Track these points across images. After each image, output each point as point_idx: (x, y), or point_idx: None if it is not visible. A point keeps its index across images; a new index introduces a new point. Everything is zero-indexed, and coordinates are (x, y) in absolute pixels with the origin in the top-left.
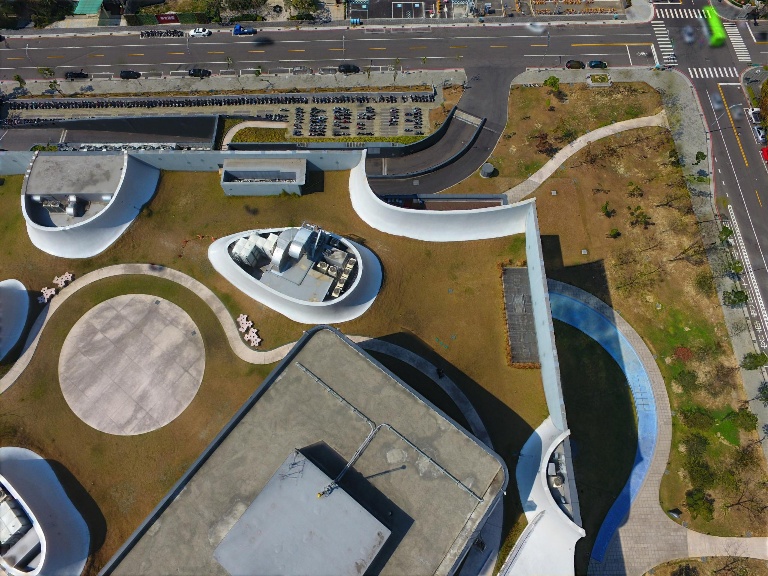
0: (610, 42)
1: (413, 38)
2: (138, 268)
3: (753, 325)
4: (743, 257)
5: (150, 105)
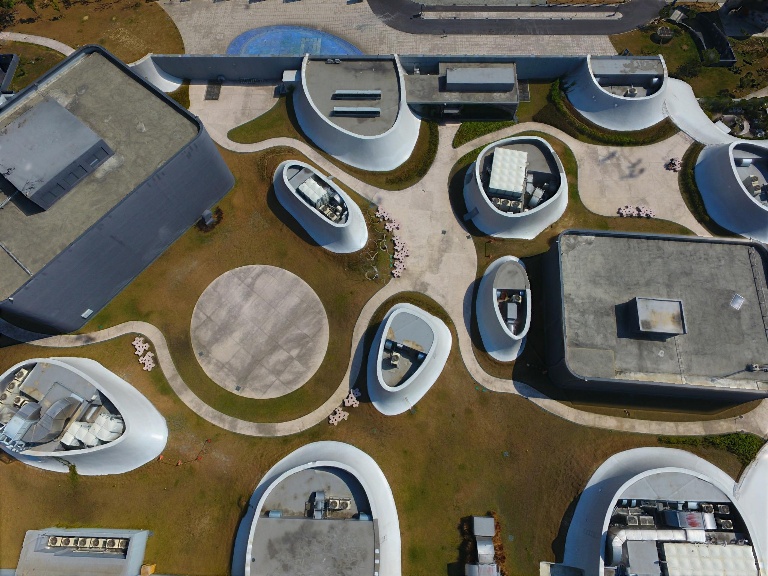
0: None
1: None
2: (260, 430)
3: None
4: None
5: None
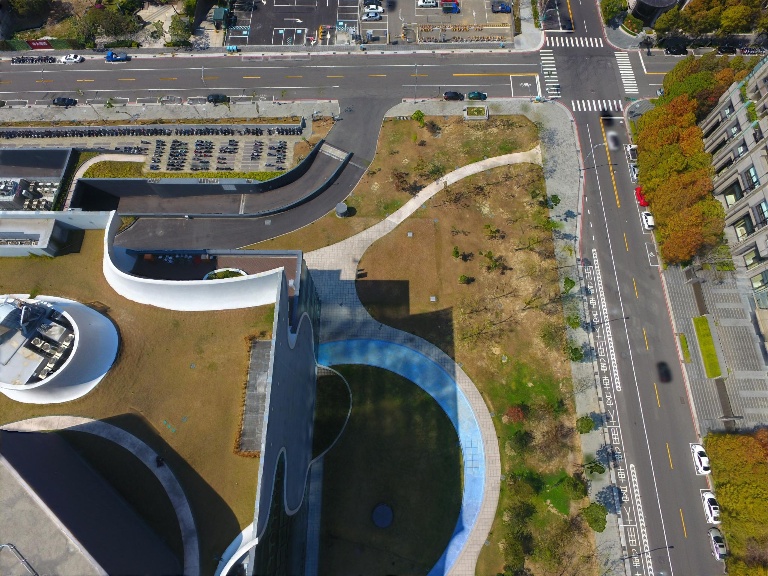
0: (493, 72)
1: (290, 66)
2: None
3: (601, 381)
4: (601, 306)
5: (8, 136)
